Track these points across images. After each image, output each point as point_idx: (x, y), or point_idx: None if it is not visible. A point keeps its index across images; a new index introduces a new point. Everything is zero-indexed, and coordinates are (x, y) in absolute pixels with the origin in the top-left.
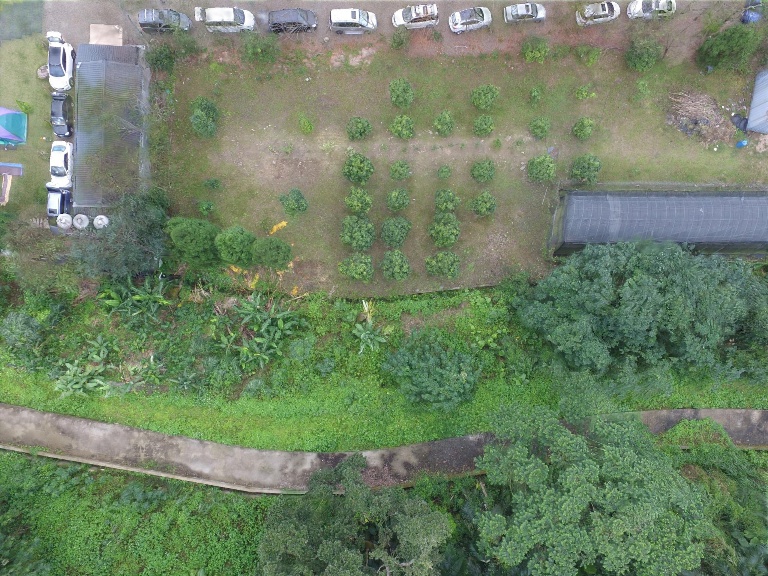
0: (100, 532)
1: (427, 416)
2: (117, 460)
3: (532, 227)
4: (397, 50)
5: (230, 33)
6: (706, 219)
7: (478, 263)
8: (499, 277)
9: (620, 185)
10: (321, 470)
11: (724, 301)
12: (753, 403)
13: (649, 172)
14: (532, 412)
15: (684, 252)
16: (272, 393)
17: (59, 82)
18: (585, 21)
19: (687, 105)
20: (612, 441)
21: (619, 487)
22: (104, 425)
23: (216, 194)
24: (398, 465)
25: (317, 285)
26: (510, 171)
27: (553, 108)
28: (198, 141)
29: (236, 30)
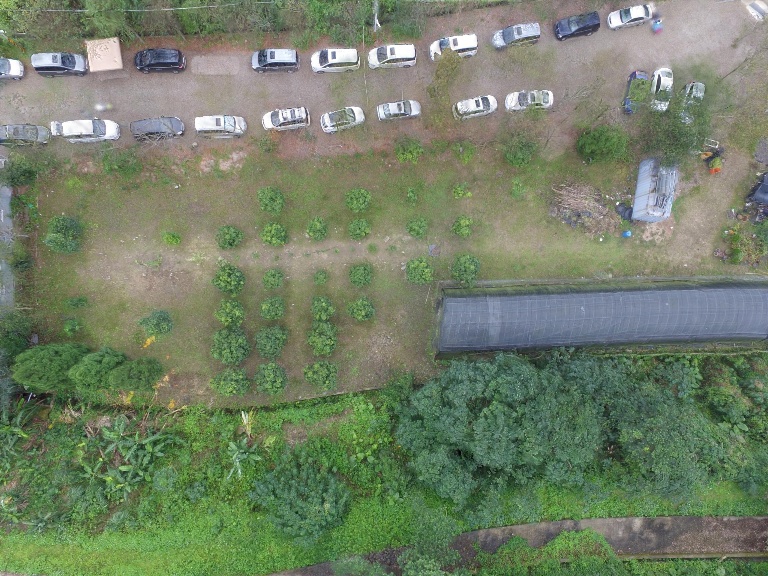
0: None
1: None
2: None
3: (416, 327)
4: (269, 153)
5: (94, 143)
6: (587, 318)
7: (362, 366)
8: (384, 379)
9: (505, 280)
10: None
11: (598, 411)
12: (634, 510)
13: (534, 266)
14: (407, 531)
15: (561, 357)
16: (137, 525)
17: None
18: (460, 117)
19: (569, 198)
20: None
21: None
22: None
23: (86, 309)
24: None
25: (194, 398)
26: (391, 271)
27: (433, 205)
28: (65, 255)
29: (99, 140)
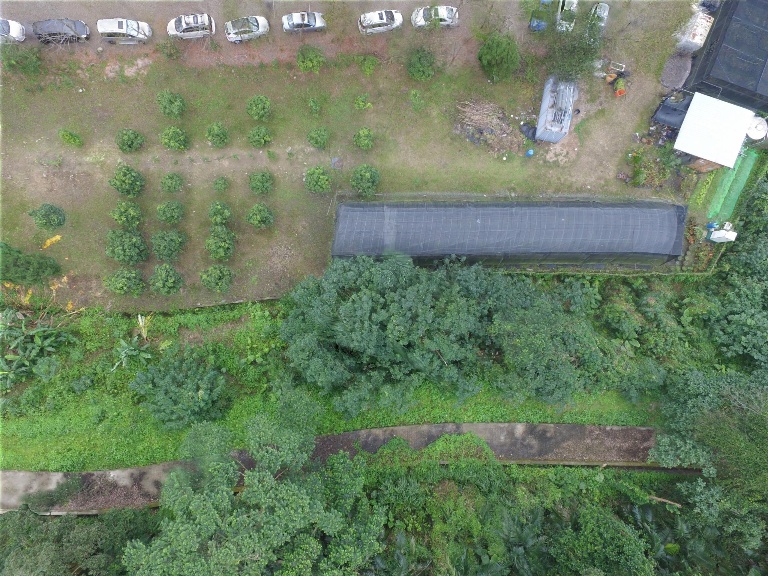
0: None
1: (180, 434)
2: None
3: (317, 239)
4: (174, 60)
5: None
6: (483, 230)
7: (261, 276)
8: (284, 290)
9: (407, 195)
10: (67, 490)
11: (482, 314)
12: (518, 417)
13: (437, 182)
14: (288, 428)
15: (451, 264)
16: (18, 412)
17: None
18: (365, 30)
19: (472, 114)
20: (264, 465)
21: (250, 514)
22: None
23: None
24: (148, 484)
25: (92, 300)
26: (293, 182)
27: (337, 118)
28: None
29: (4, 41)
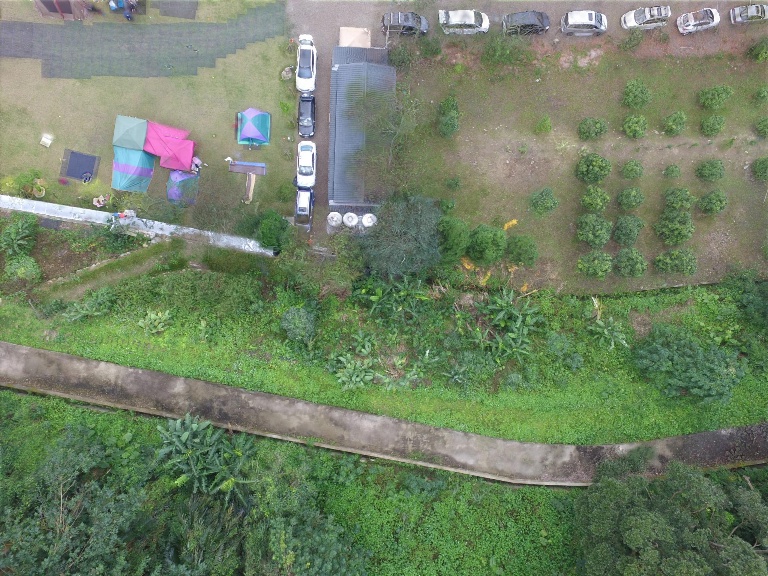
0: (391, 520)
1: (679, 410)
2: (386, 451)
3: (753, 225)
4: (625, 51)
5: (464, 35)
6: None
7: (701, 261)
8: (721, 275)
9: None
10: (580, 462)
11: None
12: None
13: None
14: None
15: None
16: (530, 387)
17: (306, 84)
18: None
19: None
20: None
21: None
22: (374, 417)
23: (449, 193)
24: (653, 458)
25: (547, 282)
26: (733, 170)
27: None
28: (432, 141)
29: (471, 32)
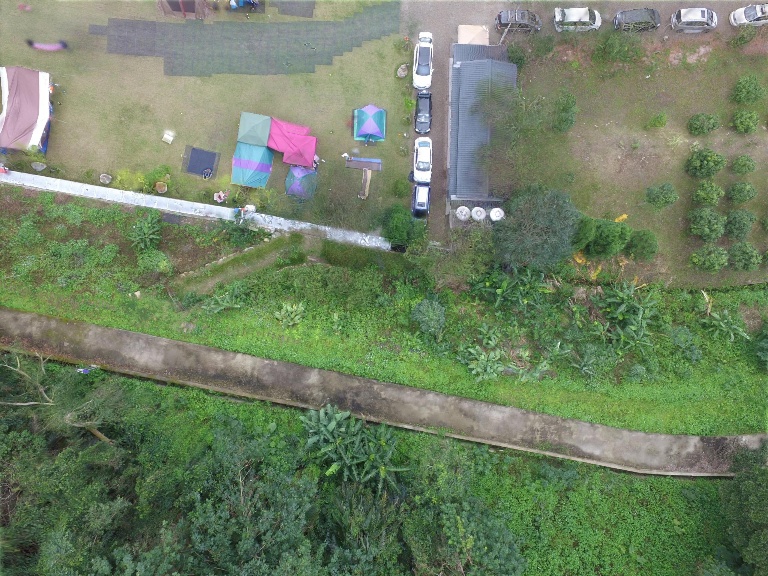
0: (530, 508)
1: None
2: (515, 441)
3: None
4: (733, 48)
5: (575, 33)
6: None
7: None
8: None
9: None
10: (704, 453)
11: None
12: None
13: None
14: None
15: None
16: (654, 379)
17: (423, 81)
18: None
19: None
20: None
21: None
22: (503, 408)
23: (561, 188)
24: None
25: (657, 276)
26: None
27: None
28: (544, 137)
29: (582, 30)
